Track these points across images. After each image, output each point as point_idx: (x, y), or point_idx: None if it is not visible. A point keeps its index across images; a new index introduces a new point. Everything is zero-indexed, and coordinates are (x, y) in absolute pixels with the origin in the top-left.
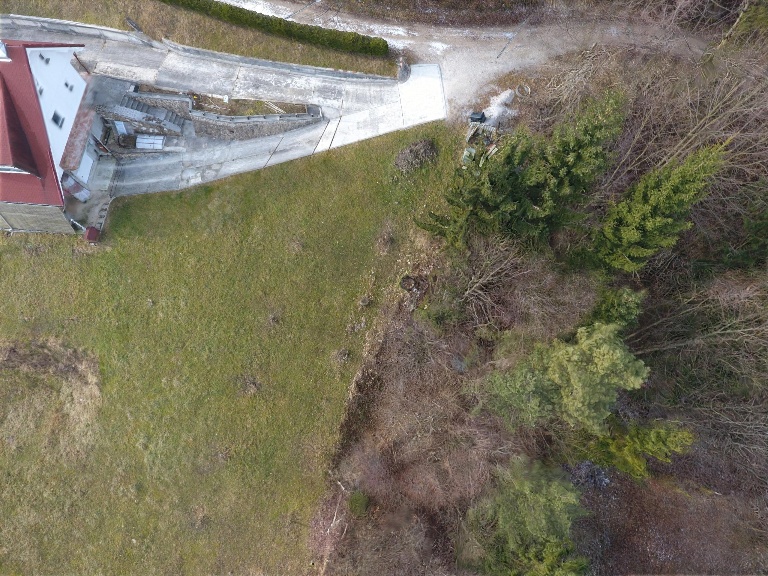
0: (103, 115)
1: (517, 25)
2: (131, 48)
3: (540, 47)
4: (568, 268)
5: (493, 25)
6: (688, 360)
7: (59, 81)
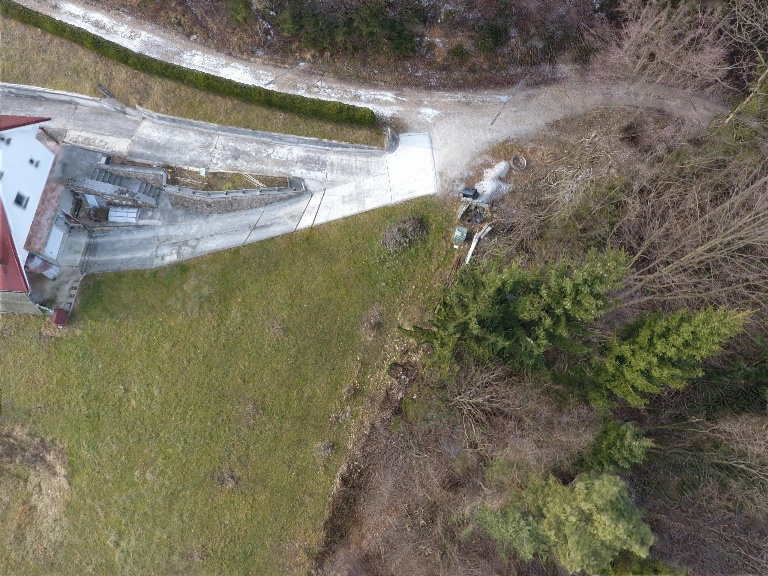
0: (73, 188)
1: (512, 87)
2: (103, 115)
3: (537, 111)
4: (566, 391)
5: (487, 88)
6: (696, 471)
7: (23, 159)
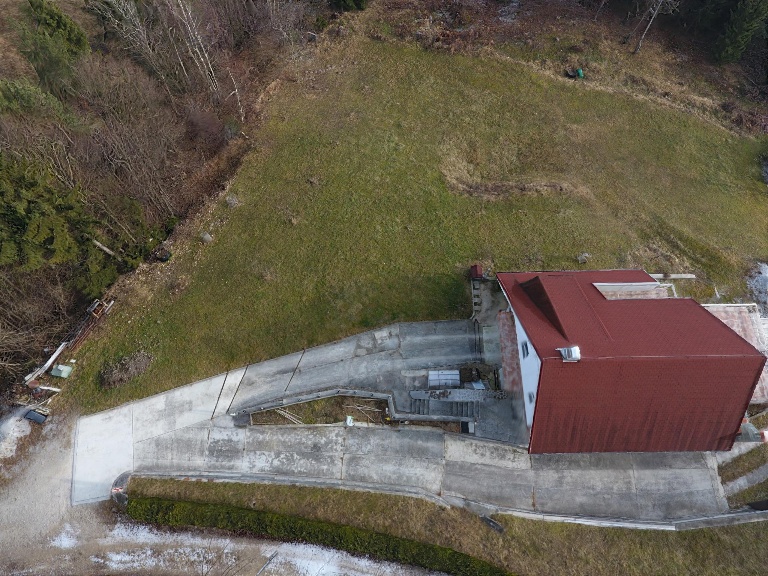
0: None
1: None
2: (494, 497)
3: None
4: None
5: None
6: None
7: None
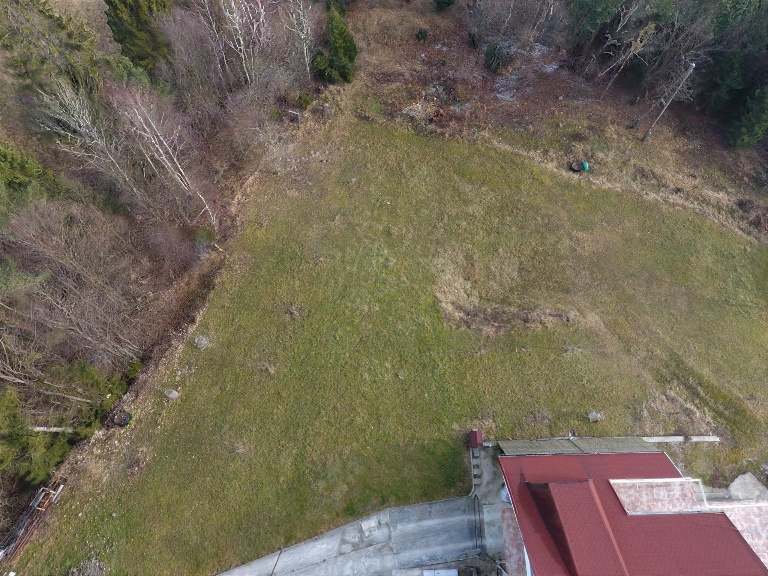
0: None
1: None
2: None
3: None
4: None
5: None
6: None
7: None
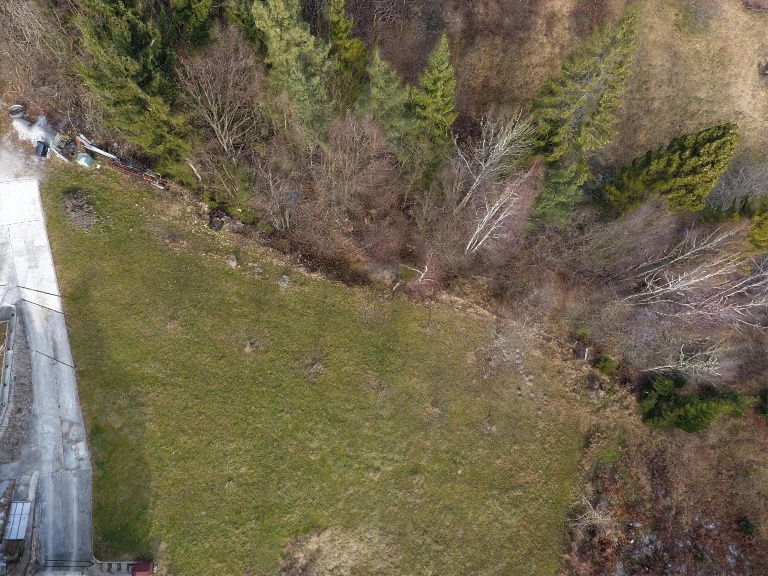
0: None
1: None
2: None
3: None
4: (207, 50)
5: None
6: None
7: None
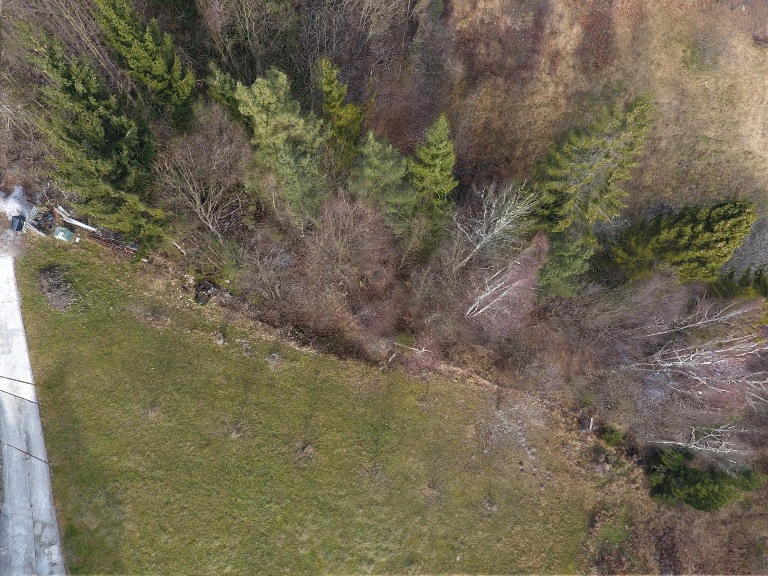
0: None
1: None
2: None
3: None
4: (189, 130)
5: None
6: None
7: None
